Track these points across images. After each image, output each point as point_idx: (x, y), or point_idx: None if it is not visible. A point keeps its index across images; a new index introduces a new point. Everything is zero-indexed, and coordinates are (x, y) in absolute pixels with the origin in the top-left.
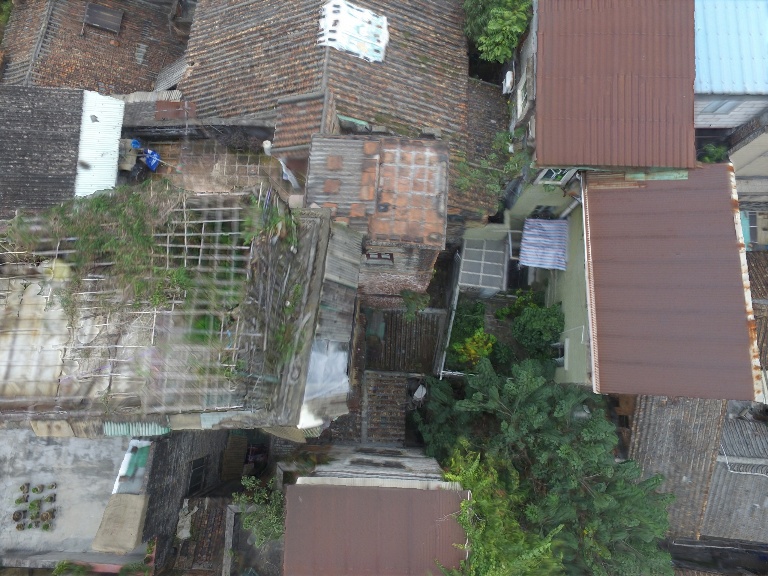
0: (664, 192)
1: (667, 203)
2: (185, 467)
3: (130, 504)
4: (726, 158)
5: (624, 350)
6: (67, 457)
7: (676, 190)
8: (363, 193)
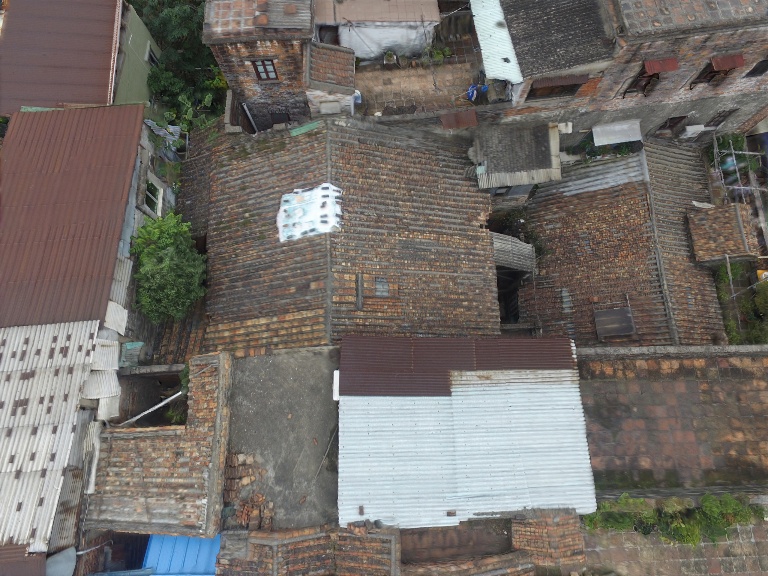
0: (44, 99)
1: (43, 91)
2: None
3: None
4: None
5: None
6: None
7: (33, 99)
8: None
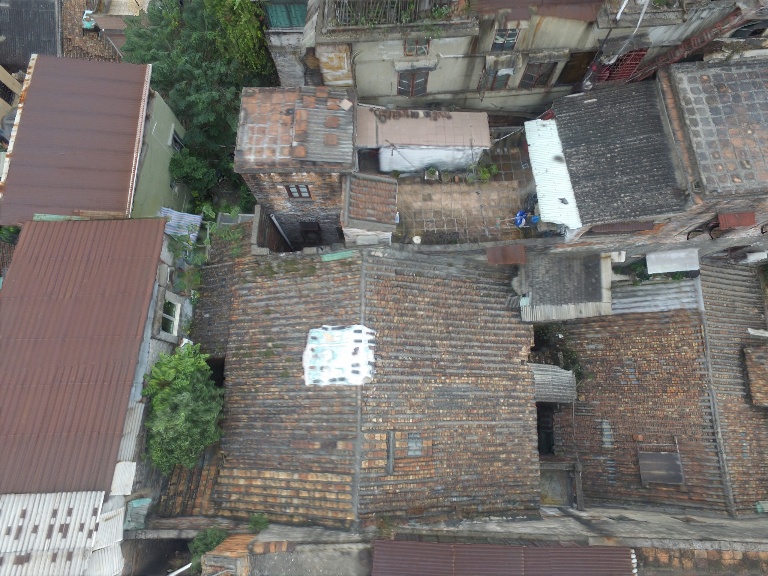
0: (59, 205)
1: (59, 196)
2: None
3: None
4: None
5: (123, 90)
6: None
7: (48, 206)
8: (305, 115)
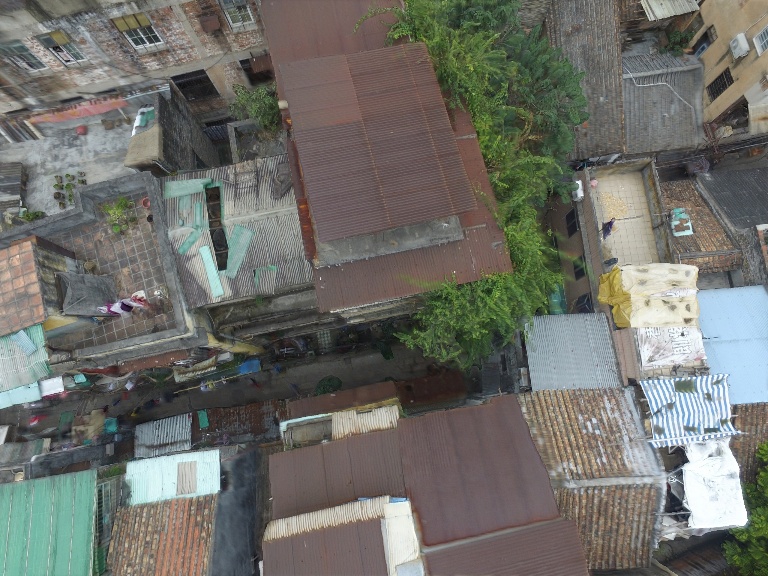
0: None
1: None
2: (189, 147)
3: (148, 135)
4: None
5: None
6: (88, 153)
7: None
8: None
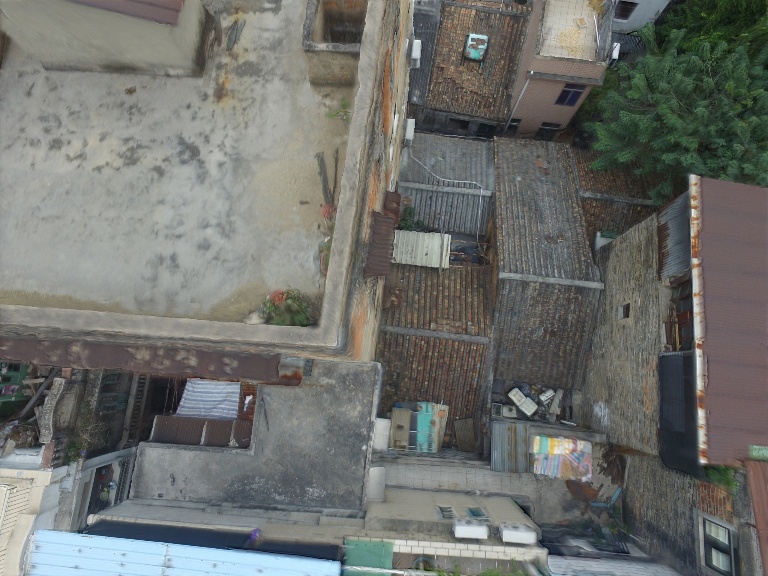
0: None
1: None
2: None
3: None
4: (709, 472)
5: None
6: None
7: (764, 431)
8: None
